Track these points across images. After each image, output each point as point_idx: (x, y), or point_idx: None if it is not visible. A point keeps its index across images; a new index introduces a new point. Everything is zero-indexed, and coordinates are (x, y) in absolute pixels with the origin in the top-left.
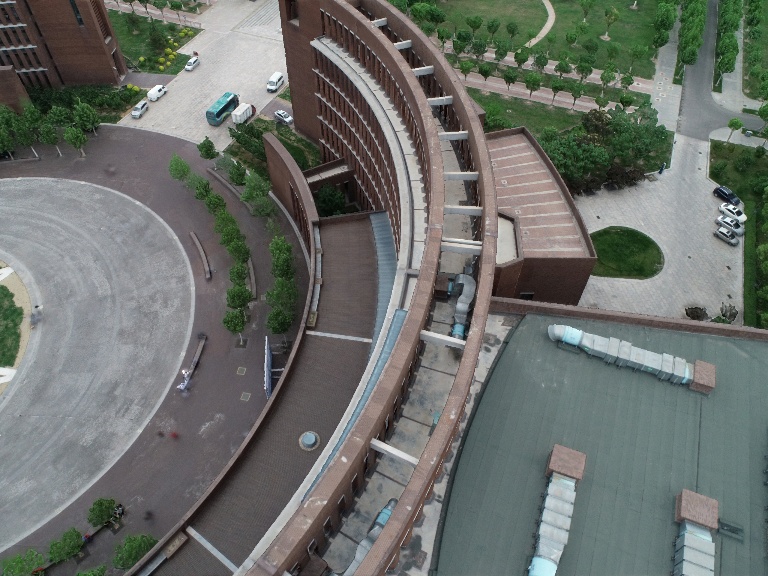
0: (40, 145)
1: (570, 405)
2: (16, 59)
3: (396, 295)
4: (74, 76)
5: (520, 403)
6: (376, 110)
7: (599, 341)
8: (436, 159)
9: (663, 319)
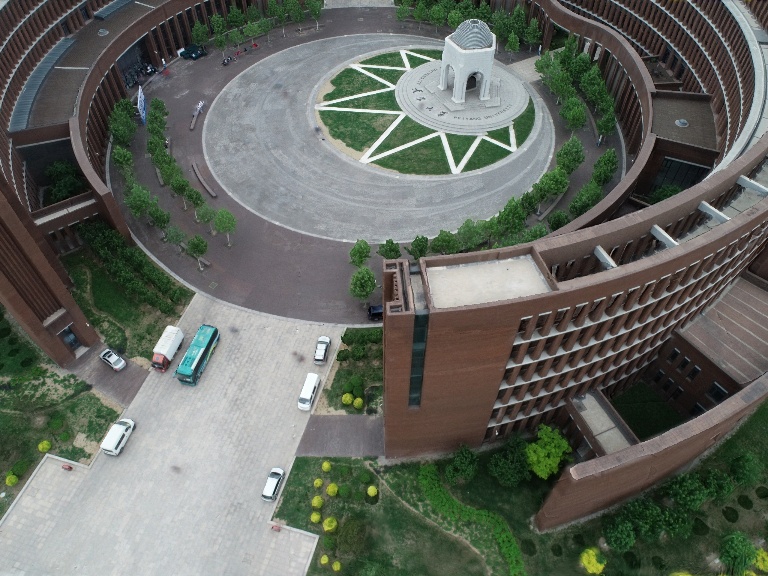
0: None
1: None
2: None
3: None
4: None
5: None
6: None
7: None
8: None
9: None
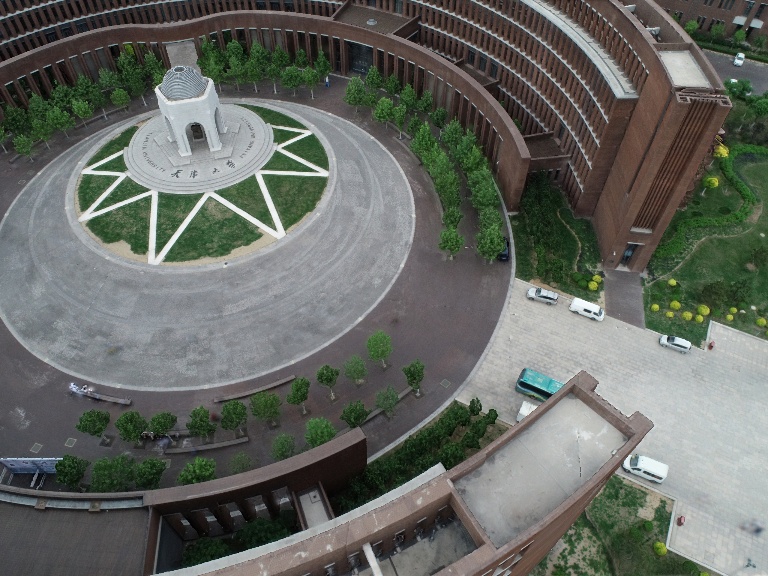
0: (470, 220)
1: None
2: (580, 161)
3: None
4: (599, 220)
5: None
6: (178, 573)
7: None
8: None
9: None
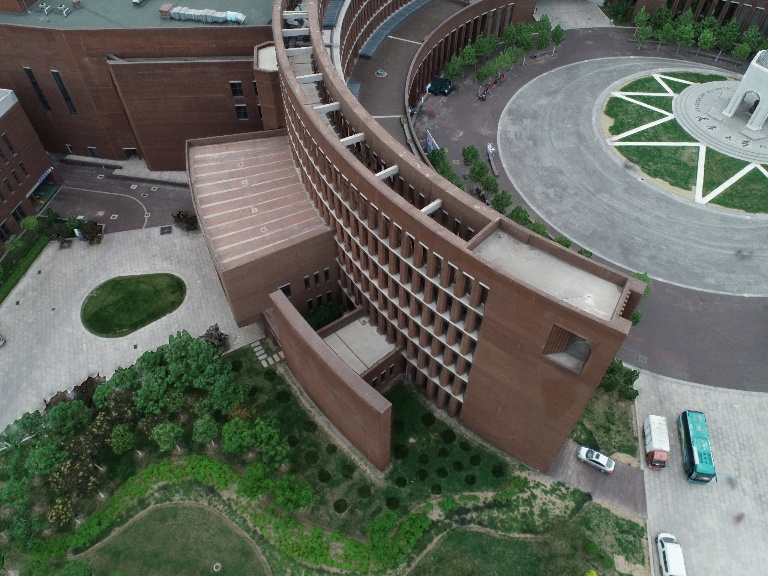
0: None
1: (240, 5)
2: None
3: (337, 35)
4: None
5: (265, 3)
6: None
7: (218, 15)
8: (317, 37)
9: (175, 27)
